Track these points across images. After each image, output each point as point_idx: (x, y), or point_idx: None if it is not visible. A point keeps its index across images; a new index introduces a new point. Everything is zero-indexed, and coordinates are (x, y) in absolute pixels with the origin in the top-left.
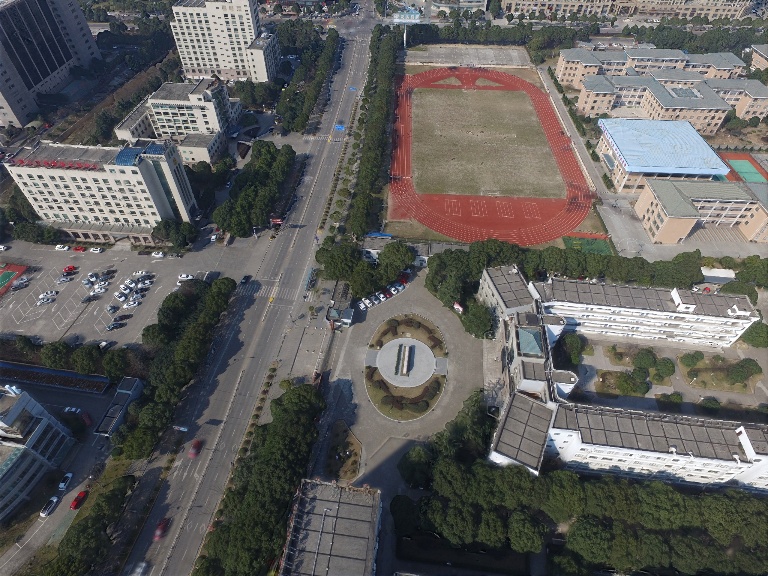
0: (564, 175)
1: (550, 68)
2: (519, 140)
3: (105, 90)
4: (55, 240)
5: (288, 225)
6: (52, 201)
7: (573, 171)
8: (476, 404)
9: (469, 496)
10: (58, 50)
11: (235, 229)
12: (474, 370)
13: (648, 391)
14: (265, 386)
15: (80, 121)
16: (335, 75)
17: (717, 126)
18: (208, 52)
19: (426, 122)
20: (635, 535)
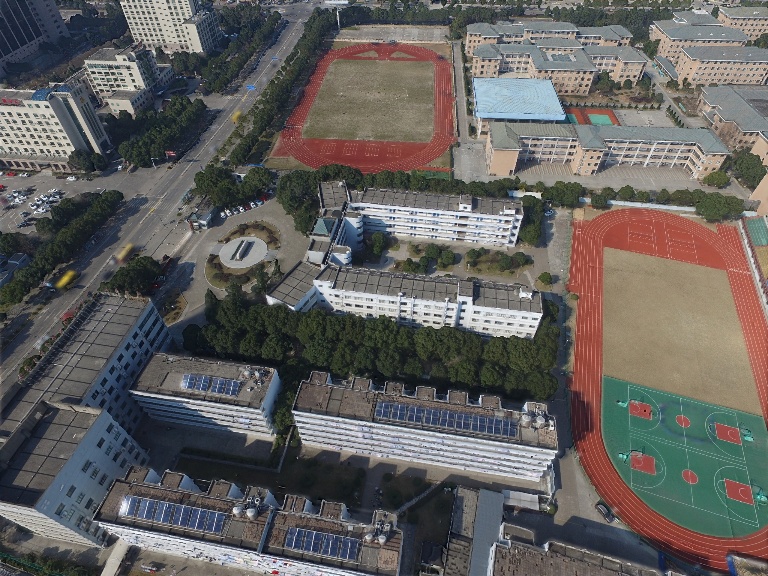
0: (436, 125)
1: (462, 42)
2: (409, 99)
3: (67, 62)
4: None
5: (185, 160)
6: None
7: (445, 122)
8: (278, 274)
9: (239, 323)
10: (28, 27)
11: (136, 159)
12: (296, 258)
13: (430, 274)
14: (126, 265)
15: (40, 85)
16: (269, 50)
17: (588, 87)
18: (155, 28)
19: (333, 85)
20: (355, 349)
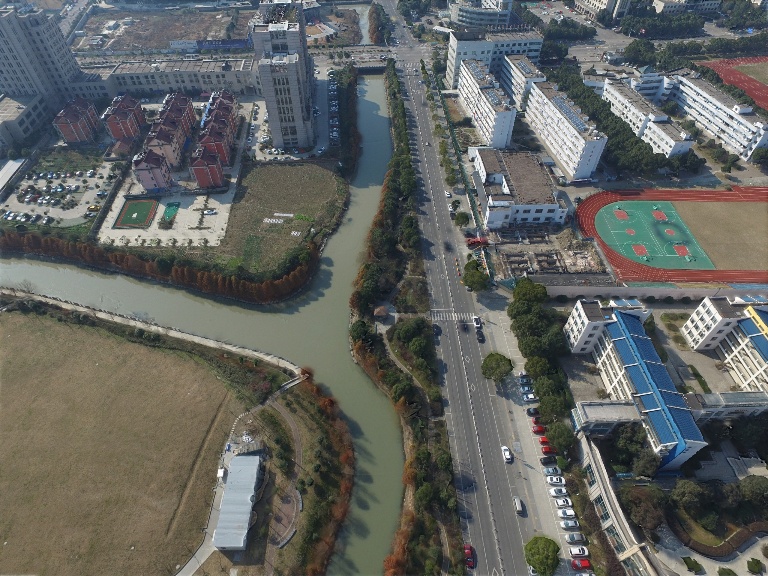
0: None
1: None
2: None
3: None
4: (569, 5)
5: None
6: None
7: None
8: None
9: None
10: None
11: (625, 27)
12: None
13: None
14: None
15: None
16: None
17: None
18: None
19: None
20: None
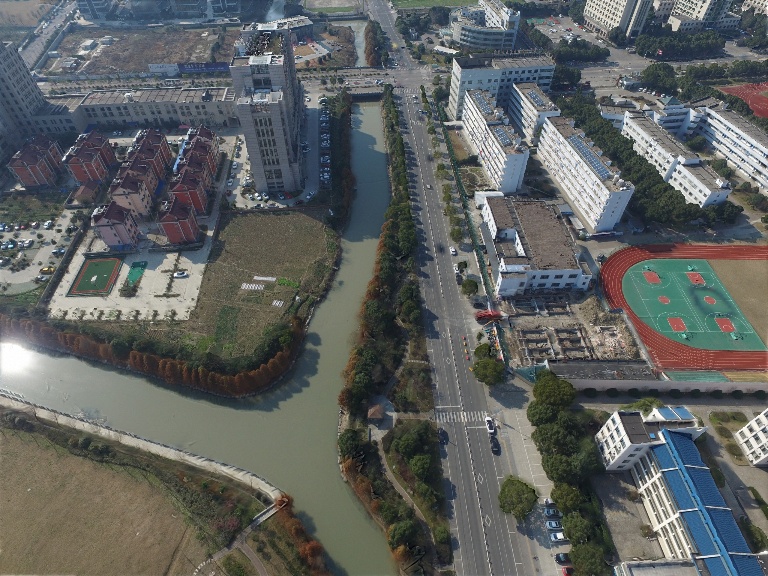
0: None
1: None
2: None
3: None
4: (578, 21)
5: None
6: (593, 2)
7: None
8: None
9: None
10: None
11: (640, 47)
12: None
13: None
14: None
15: None
16: None
17: None
18: None
19: None
20: None
